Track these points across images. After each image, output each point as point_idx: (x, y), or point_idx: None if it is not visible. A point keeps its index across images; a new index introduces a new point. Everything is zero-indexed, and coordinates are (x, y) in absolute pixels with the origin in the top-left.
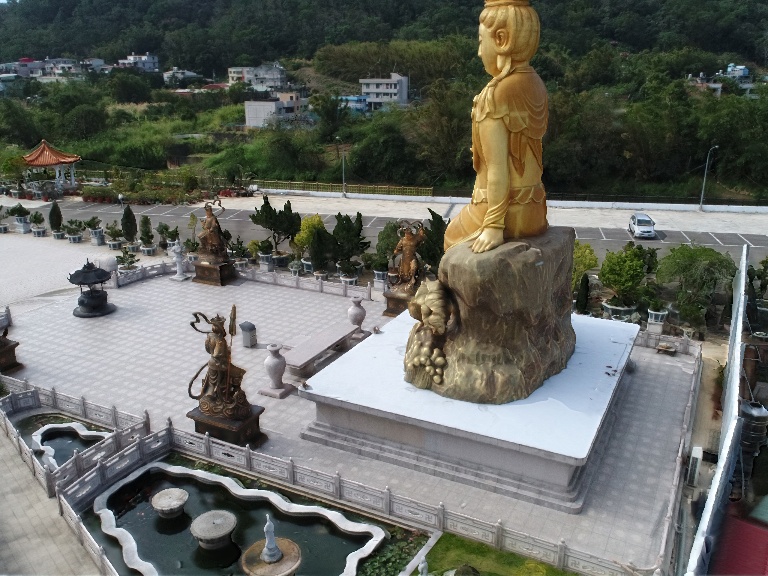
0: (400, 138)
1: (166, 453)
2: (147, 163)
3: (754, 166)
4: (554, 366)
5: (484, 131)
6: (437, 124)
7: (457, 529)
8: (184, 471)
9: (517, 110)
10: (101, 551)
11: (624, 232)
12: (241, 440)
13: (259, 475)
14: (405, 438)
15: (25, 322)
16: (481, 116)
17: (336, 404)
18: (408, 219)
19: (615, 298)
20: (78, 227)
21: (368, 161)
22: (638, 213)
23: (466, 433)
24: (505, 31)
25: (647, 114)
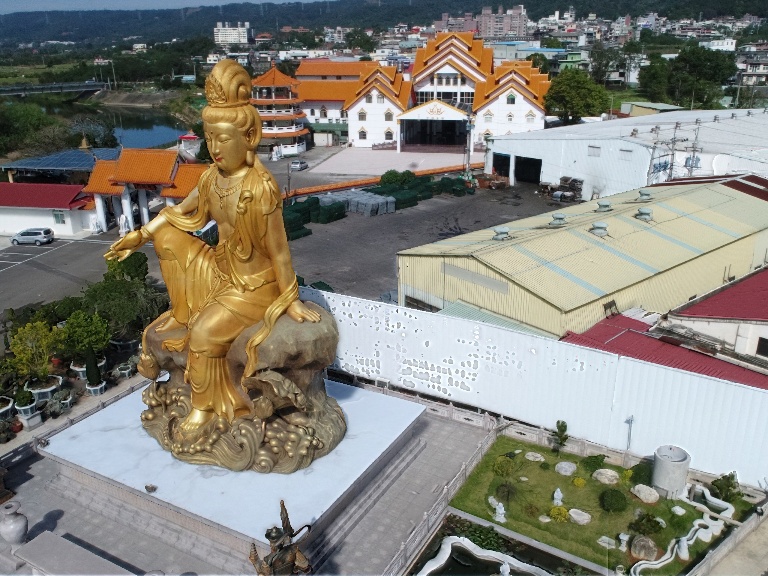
0: None
1: None
2: None
3: None
4: None
5: None
6: None
7: None
8: None
9: None
10: None
11: None
12: None
13: None
14: None
15: None
16: (272, 208)
17: None
18: None
19: (78, 361)
20: None
21: None
22: None
23: None
24: (254, 129)
25: None
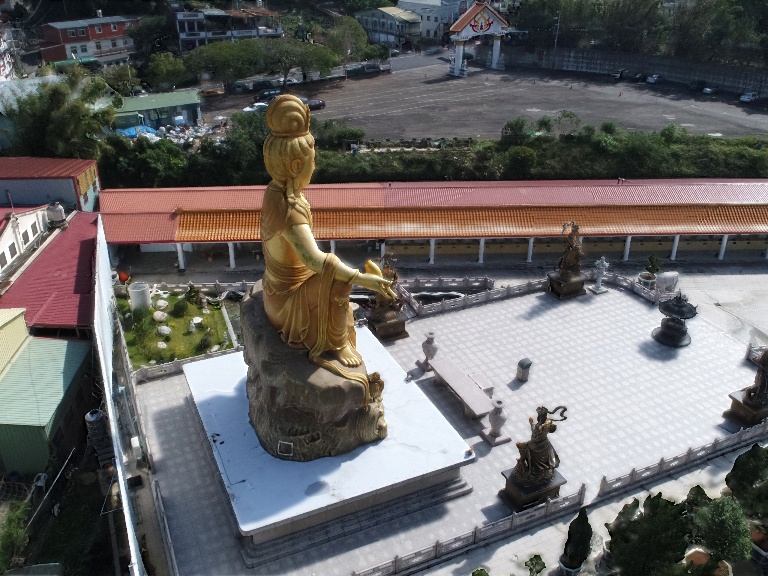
0: None
1: None
2: None
3: None
4: None
5: None
6: None
7: None
8: None
9: None
10: None
11: None
12: None
13: None
14: None
15: None
16: None
17: None
18: None
19: None
20: None
21: None
22: None
23: None
24: None
25: None
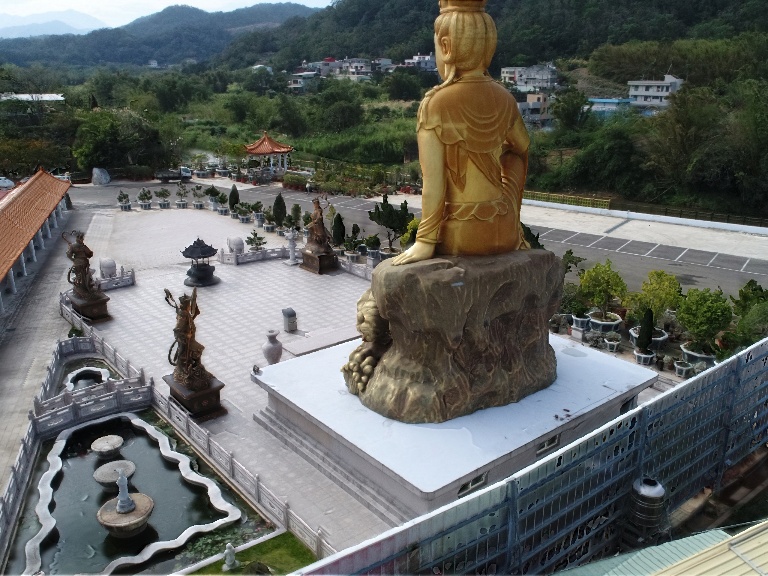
0: (628, 145)
1: (145, 407)
2: (386, 157)
3: None
4: (497, 397)
5: (419, 142)
6: (670, 132)
7: (296, 530)
8: (141, 424)
9: (452, 121)
10: (12, 468)
11: None
12: (195, 408)
13: (192, 442)
14: (320, 437)
15: (146, 283)
16: None
17: (271, 392)
18: (563, 231)
19: None
20: (248, 209)
21: (590, 168)
22: None
23: (348, 442)
24: (448, 39)
25: None
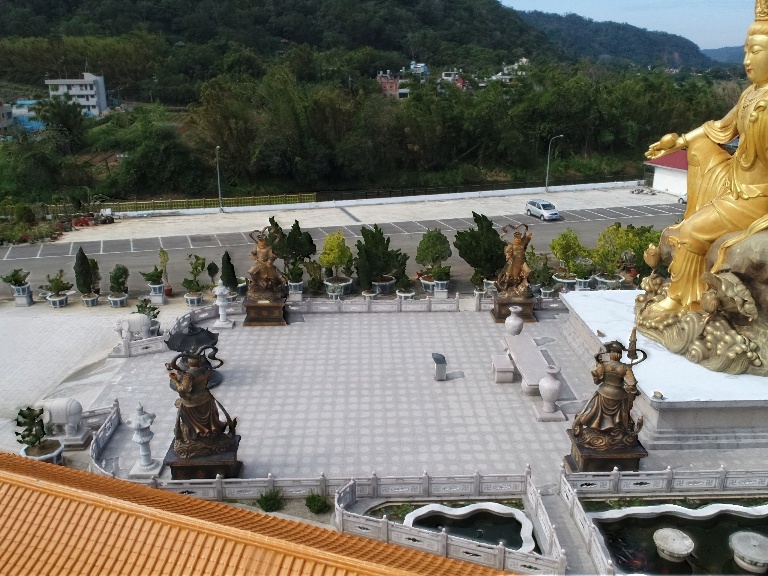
0: (182, 144)
1: None
2: None
3: (511, 151)
4: None
5: None
6: (223, 127)
7: None
8: (623, 513)
9: None
10: None
11: (527, 217)
12: None
13: (683, 493)
14: (754, 422)
15: None
16: None
17: (700, 406)
18: (328, 227)
19: None
20: None
21: (148, 172)
22: (533, 199)
23: None
24: None
25: (417, 109)
